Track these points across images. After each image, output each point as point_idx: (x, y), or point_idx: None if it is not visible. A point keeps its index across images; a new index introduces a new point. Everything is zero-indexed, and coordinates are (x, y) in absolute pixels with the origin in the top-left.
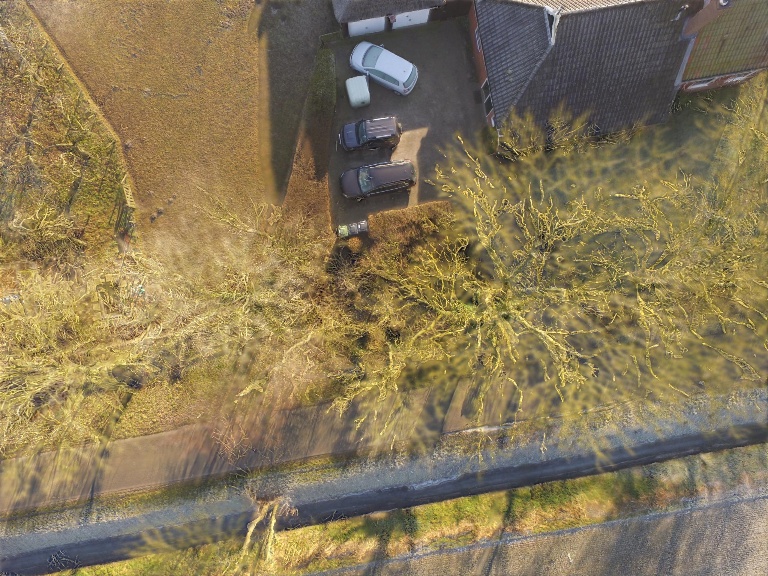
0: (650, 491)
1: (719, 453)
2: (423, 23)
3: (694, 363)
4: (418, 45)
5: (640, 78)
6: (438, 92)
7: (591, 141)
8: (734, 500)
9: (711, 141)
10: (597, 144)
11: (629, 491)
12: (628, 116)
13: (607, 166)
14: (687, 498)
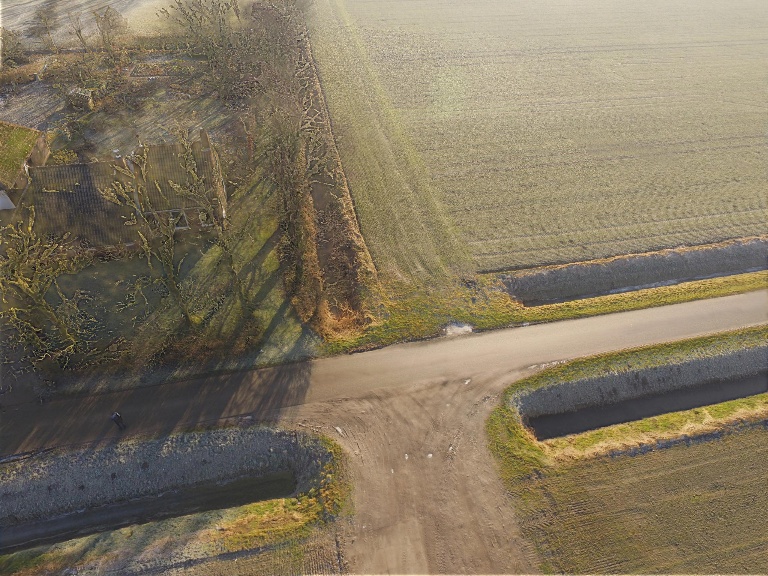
0: (33, 566)
1: (156, 522)
2: (14, 209)
3: (135, 410)
4: (3, 217)
5: (107, 208)
6: (2, 237)
7: (98, 257)
8: (134, 570)
9: (195, 258)
10: (106, 260)
11: (7, 569)
12: (111, 234)
13: (108, 272)
14: (71, 569)
